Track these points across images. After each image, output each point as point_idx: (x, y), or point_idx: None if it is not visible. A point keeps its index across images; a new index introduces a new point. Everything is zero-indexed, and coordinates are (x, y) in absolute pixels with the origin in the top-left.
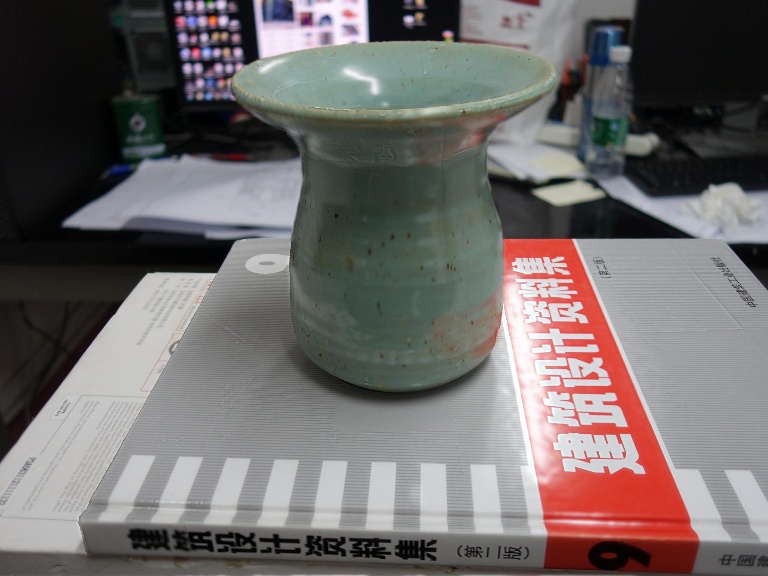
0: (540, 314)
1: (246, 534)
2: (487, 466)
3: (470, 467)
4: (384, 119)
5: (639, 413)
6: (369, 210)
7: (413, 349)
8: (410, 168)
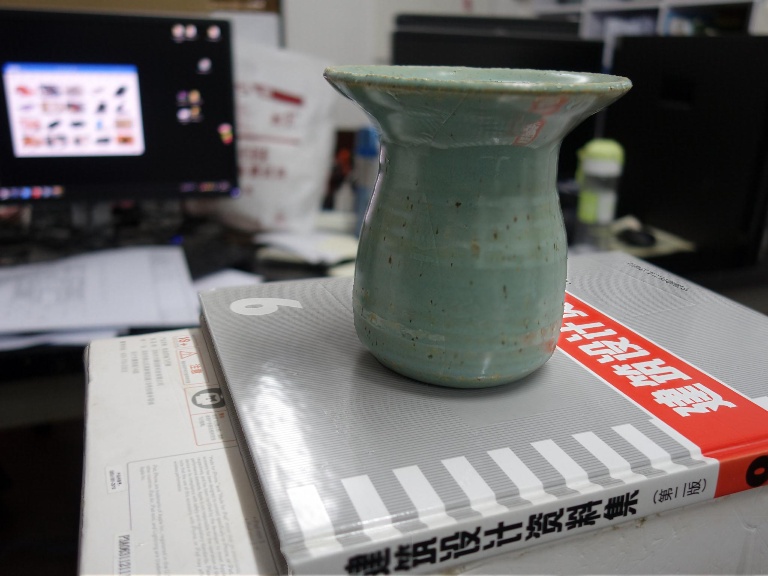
0: None
1: (472, 530)
2: (624, 425)
3: (612, 429)
4: (561, 91)
5: (690, 368)
6: (494, 195)
7: (529, 331)
8: (537, 150)
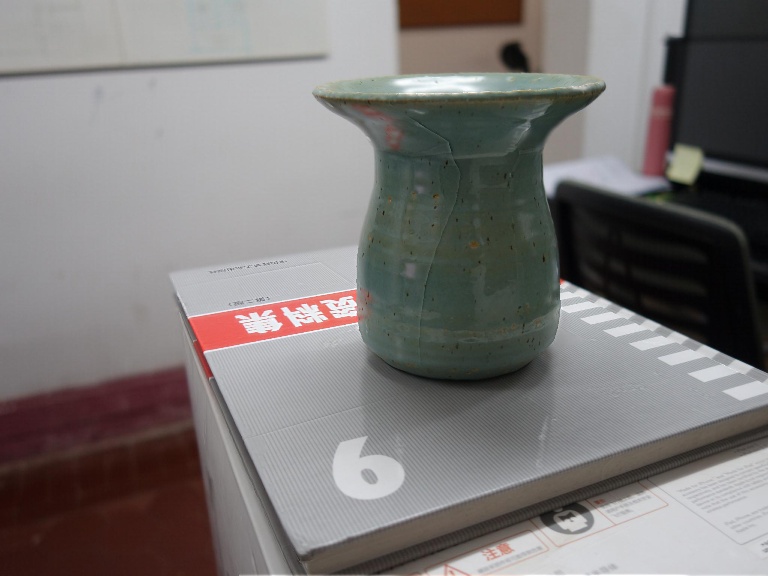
0: (353, 310)
1: None
2: None
3: None
4: None
5: None
6: None
7: None
8: None
